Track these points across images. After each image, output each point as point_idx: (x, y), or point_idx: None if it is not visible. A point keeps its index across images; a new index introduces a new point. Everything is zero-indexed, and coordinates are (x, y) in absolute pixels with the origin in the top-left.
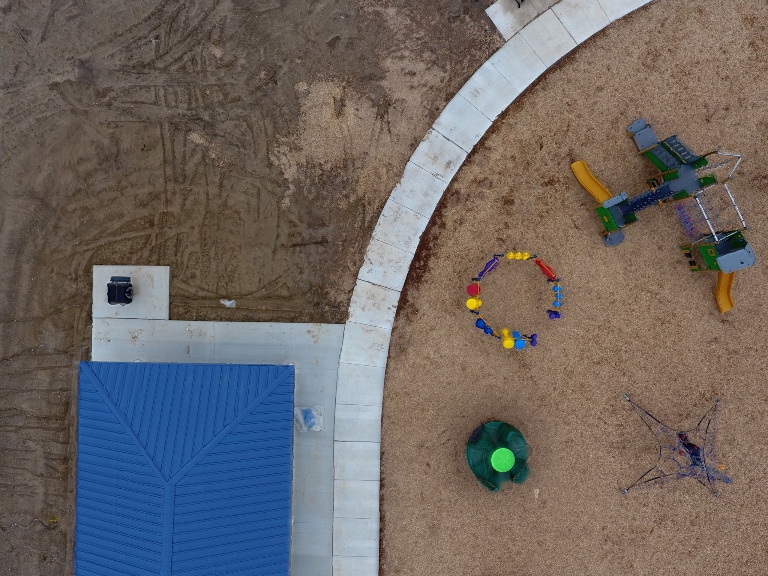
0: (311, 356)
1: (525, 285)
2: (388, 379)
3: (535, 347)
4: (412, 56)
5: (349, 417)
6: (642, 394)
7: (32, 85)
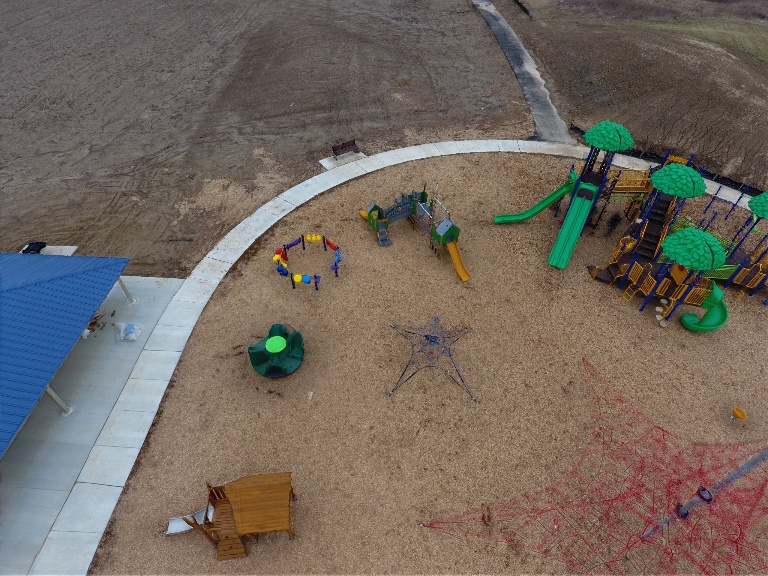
0: (152, 295)
1: (322, 264)
2: (205, 311)
3: (325, 297)
4: (274, 173)
5: (163, 334)
6: (406, 325)
7: (52, 180)
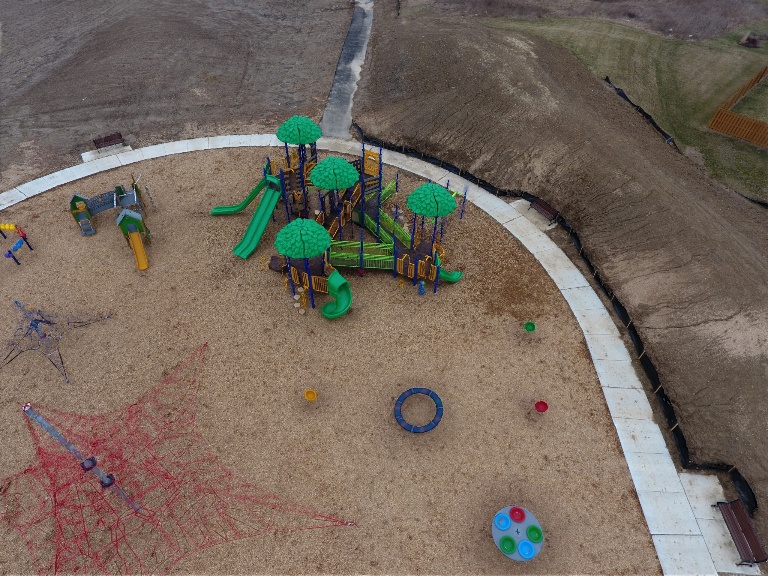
0: None
1: None
2: None
3: None
4: None
5: None
6: (53, 311)
7: None
